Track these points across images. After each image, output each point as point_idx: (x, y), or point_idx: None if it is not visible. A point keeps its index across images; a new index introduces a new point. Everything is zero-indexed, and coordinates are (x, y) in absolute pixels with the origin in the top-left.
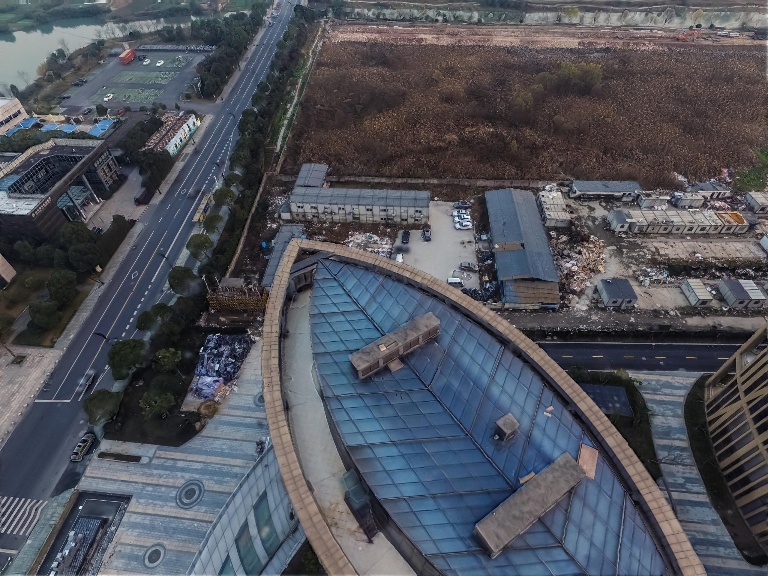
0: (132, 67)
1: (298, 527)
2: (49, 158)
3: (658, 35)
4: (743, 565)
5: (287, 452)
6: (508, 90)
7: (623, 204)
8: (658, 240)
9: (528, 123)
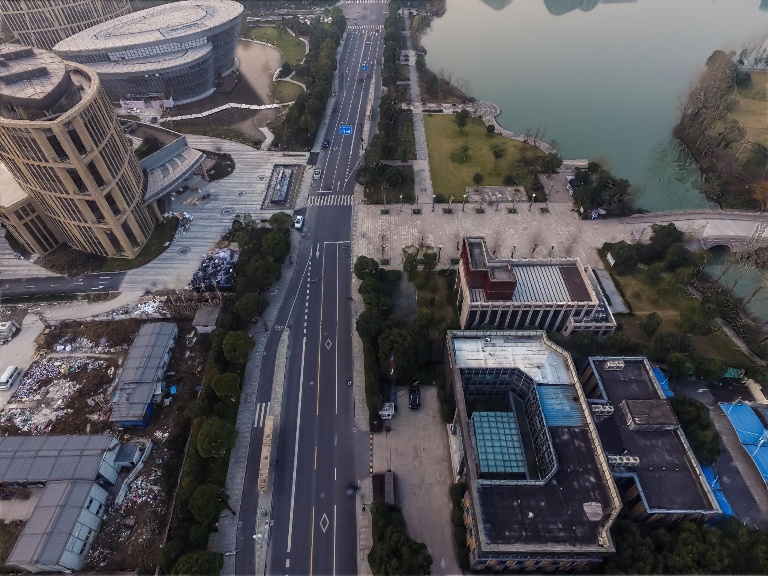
0: None
1: (149, 171)
2: None
3: None
4: None
5: None
6: None
7: None
8: None
9: None
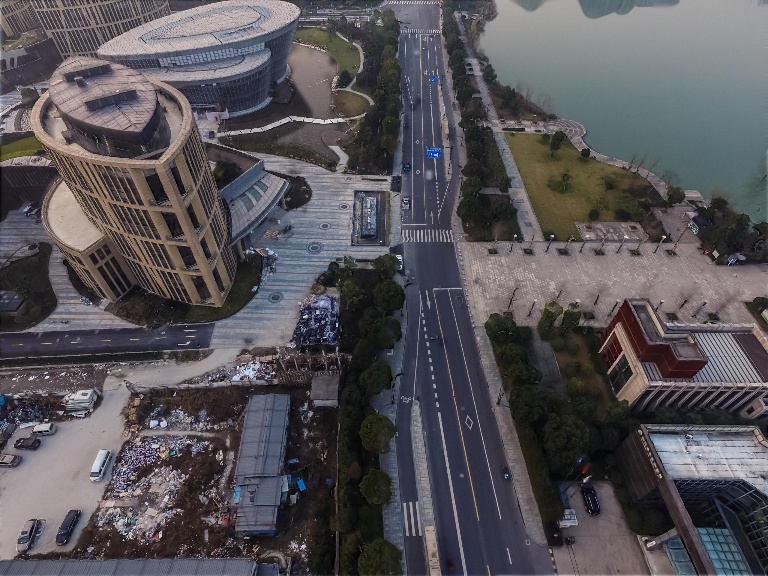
0: None
1: (230, 202)
2: None
3: None
4: (2, 237)
5: (183, 101)
6: None
7: None
8: None
9: None
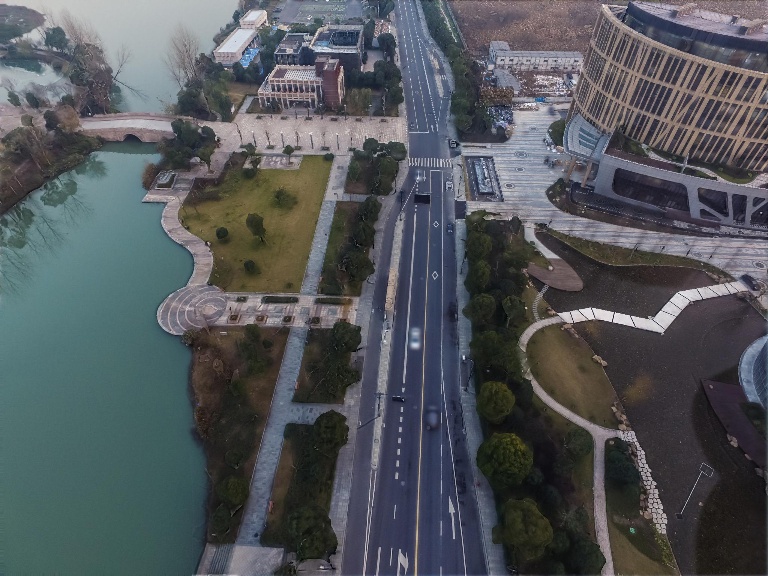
0: (307, 2)
1: None
2: (336, 33)
3: None
4: None
5: None
6: (594, 13)
7: None
8: None
9: None
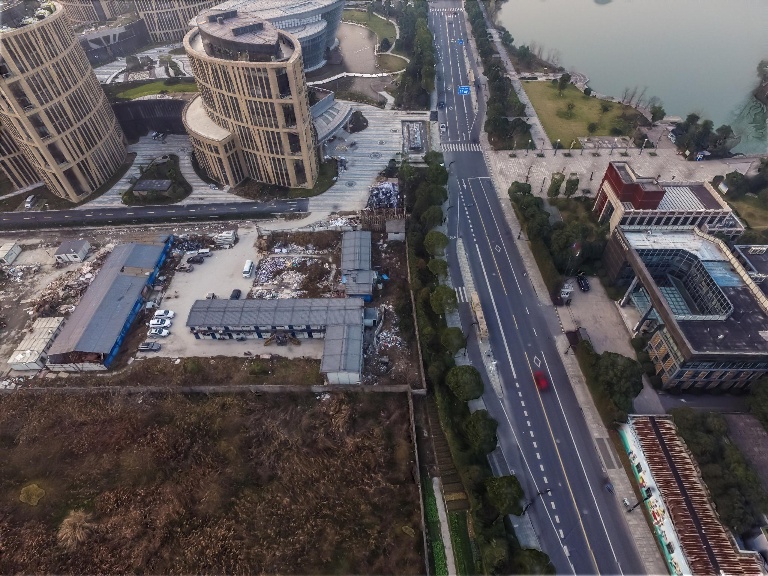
0: None
1: None
2: None
3: None
4: None
5: None
6: None
7: None
8: None
9: None
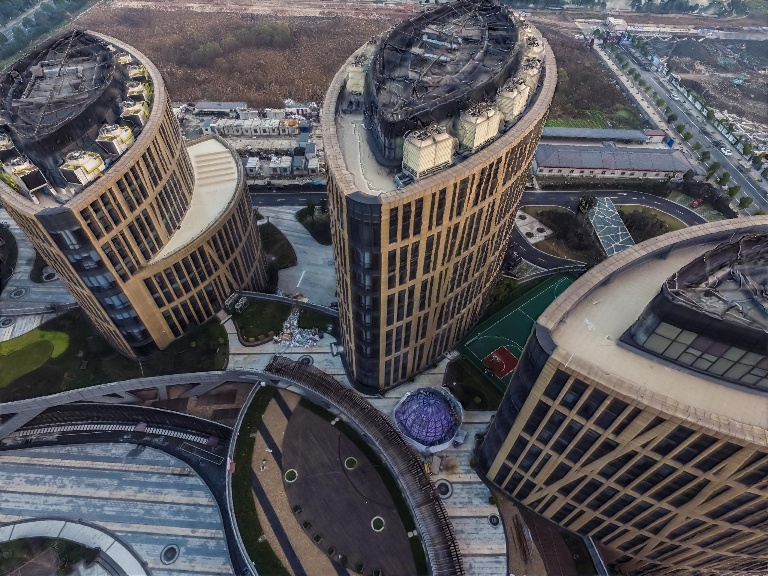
0: None
1: None
2: None
3: (388, 7)
4: None
5: None
6: None
7: (229, 118)
8: (230, 139)
9: (206, 65)
